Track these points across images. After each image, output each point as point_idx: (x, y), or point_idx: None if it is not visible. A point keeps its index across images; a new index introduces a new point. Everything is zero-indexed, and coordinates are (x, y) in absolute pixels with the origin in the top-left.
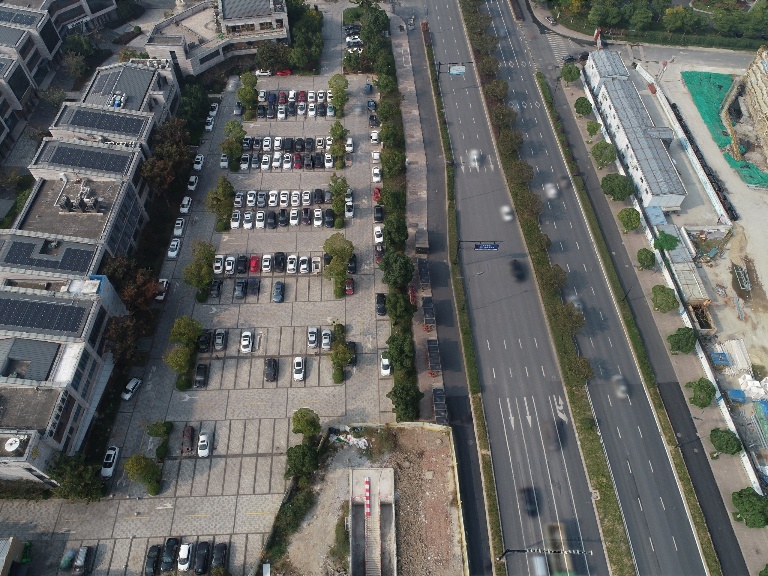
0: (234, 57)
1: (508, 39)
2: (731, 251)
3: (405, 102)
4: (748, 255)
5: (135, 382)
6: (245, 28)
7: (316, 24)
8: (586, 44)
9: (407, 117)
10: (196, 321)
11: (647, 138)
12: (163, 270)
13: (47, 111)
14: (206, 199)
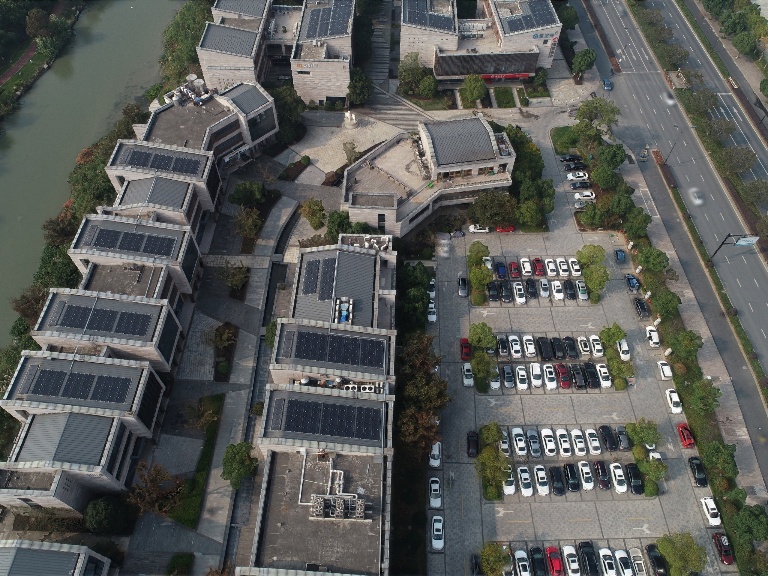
0: (441, 207)
1: (767, 177)
2: None
3: None
4: None
5: None
6: (460, 174)
7: (542, 164)
8: None
9: (681, 301)
10: None
11: None
12: (430, 571)
13: (216, 286)
14: (457, 440)
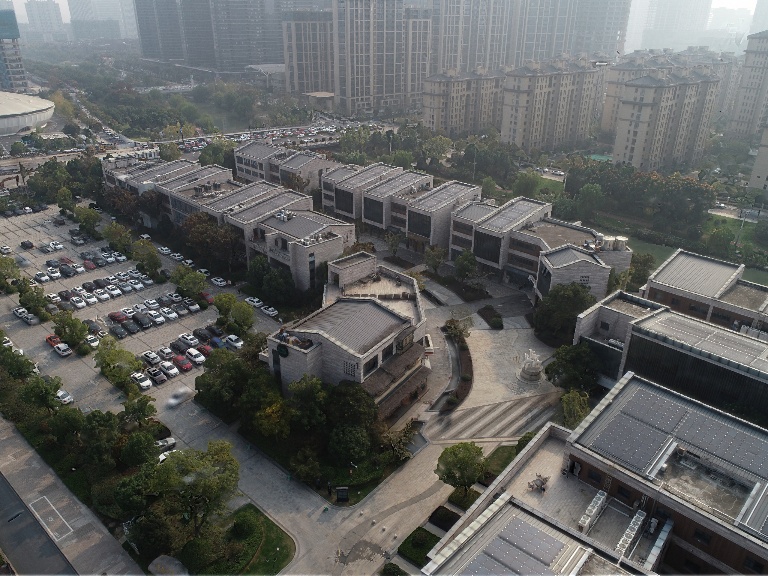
0: None
1: None
2: None
3: (7, 435)
4: None
5: (112, 218)
6: None
7: None
8: None
9: None
10: (84, 216)
11: None
12: None
13: (409, 257)
14: None
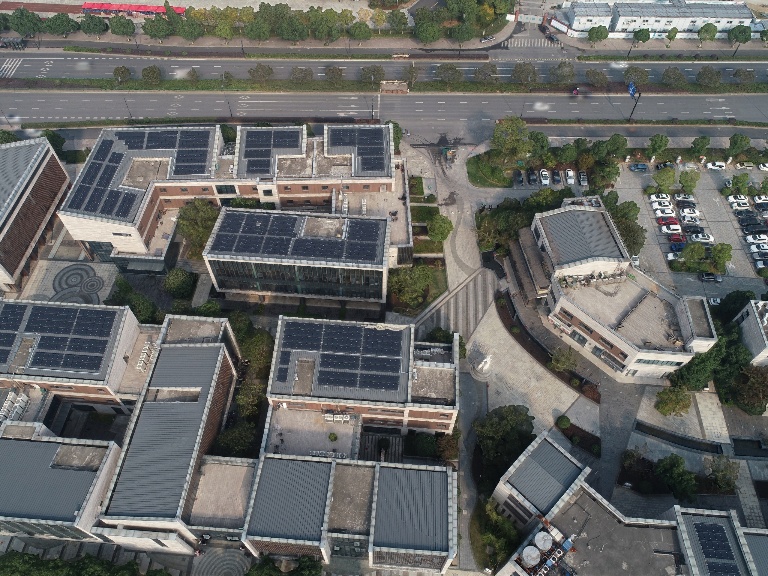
0: None
1: None
2: (759, 10)
3: None
4: (759, 5)
5: None
6: None
7: None
8: (522, 27)
9: (671, 145)
10: None
11: (691, 8)
12: None
13: None
14: None
